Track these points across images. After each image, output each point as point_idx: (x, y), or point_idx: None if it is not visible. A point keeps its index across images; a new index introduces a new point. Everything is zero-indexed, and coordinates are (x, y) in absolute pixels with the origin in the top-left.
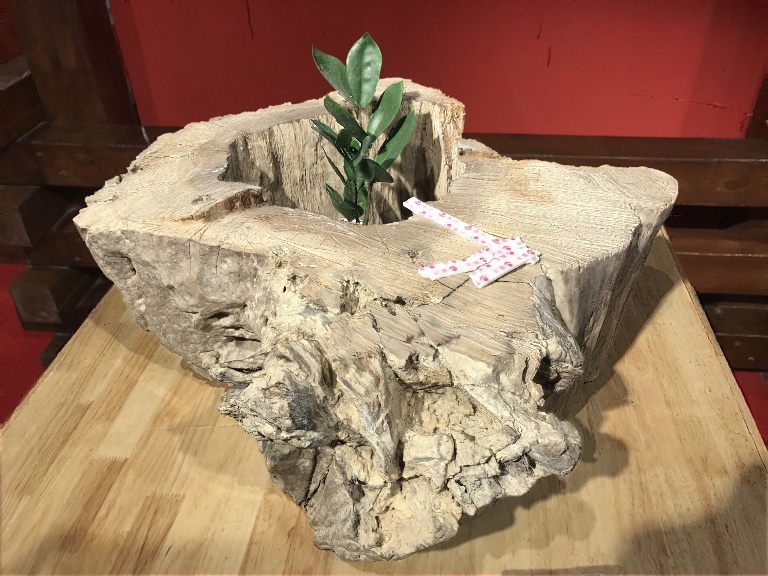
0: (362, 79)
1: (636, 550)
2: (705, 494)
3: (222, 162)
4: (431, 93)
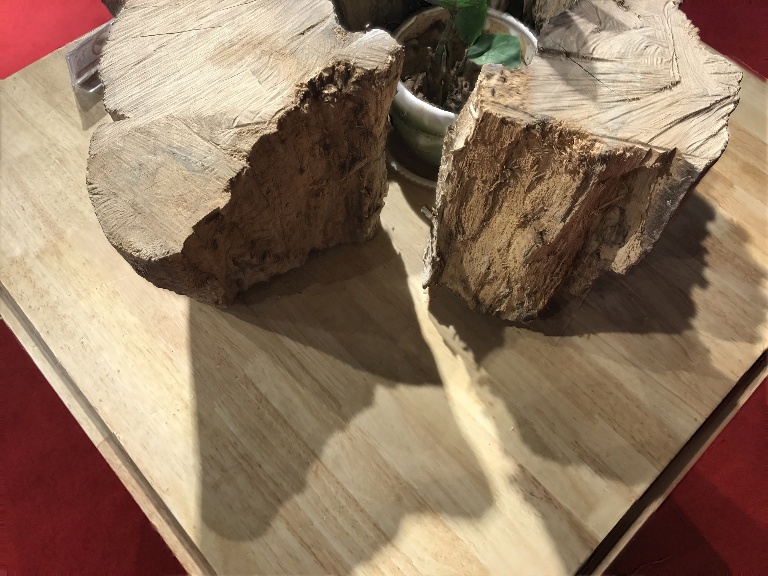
0: None
1: (79, 146)
2: (48, 223)
3: None
4: (575, 114)
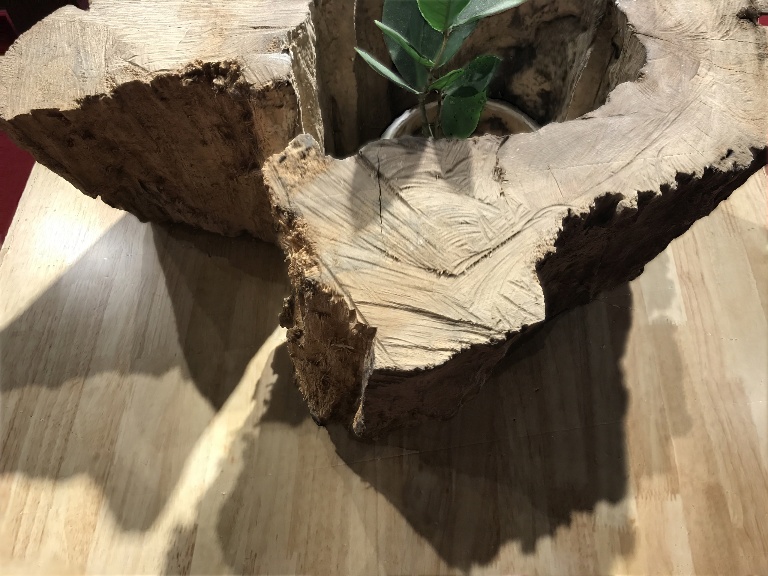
0: (449, 7)
1: None
2: None
3: (628, 8)
4: (325, 227)
